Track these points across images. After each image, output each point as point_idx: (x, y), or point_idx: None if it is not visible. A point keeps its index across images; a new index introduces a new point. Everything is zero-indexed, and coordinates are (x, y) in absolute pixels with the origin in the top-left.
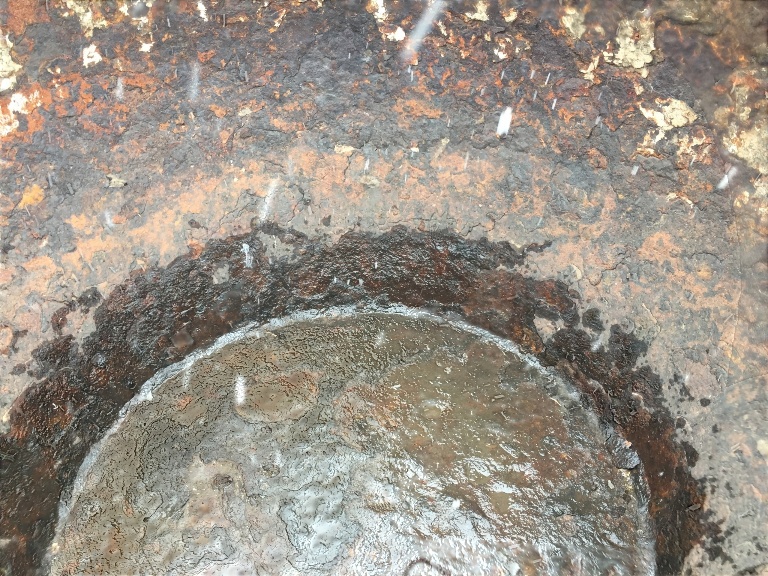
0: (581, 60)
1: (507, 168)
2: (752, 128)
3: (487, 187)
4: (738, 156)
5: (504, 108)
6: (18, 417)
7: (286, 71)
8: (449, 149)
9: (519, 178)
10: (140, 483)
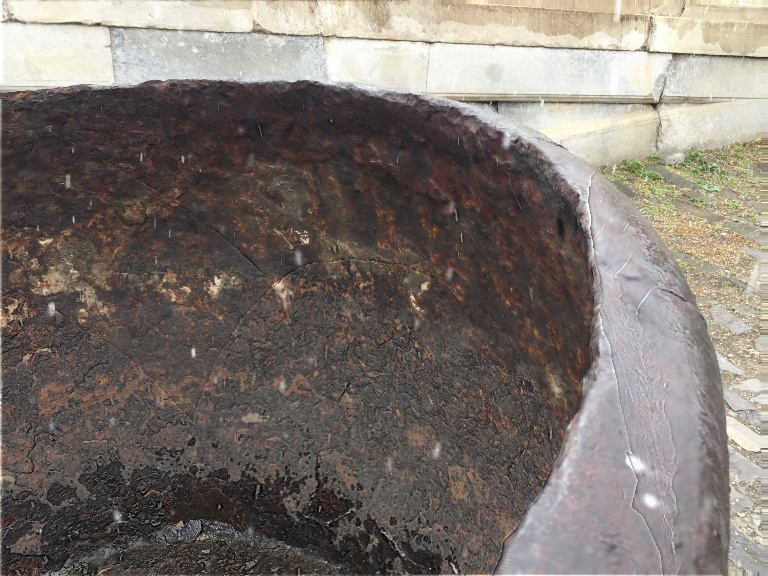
0: None
1: None
2: (48, 270)
3: None
4: (54, 293)
5: None
6: None
7: None
8: None
9: None
10: None
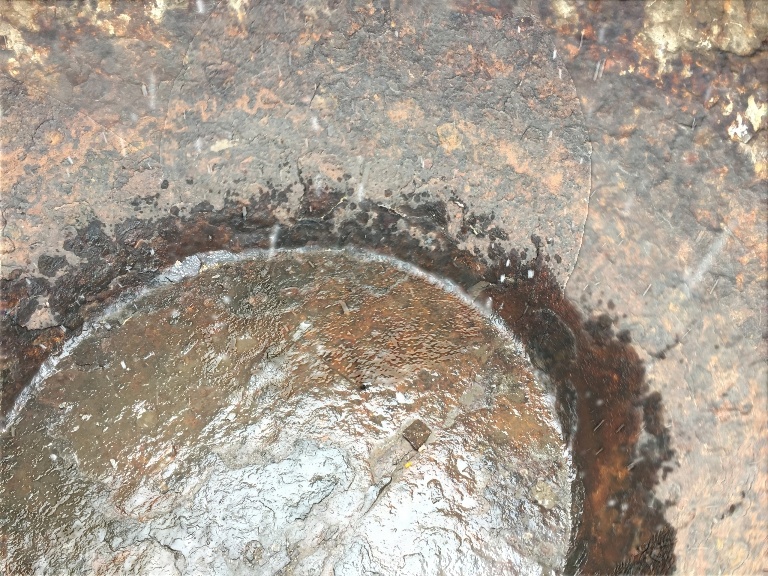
0: None
1: None
2: None
3: None
4: None
5: None
6: None
7: None
8: None
9: None
10: None
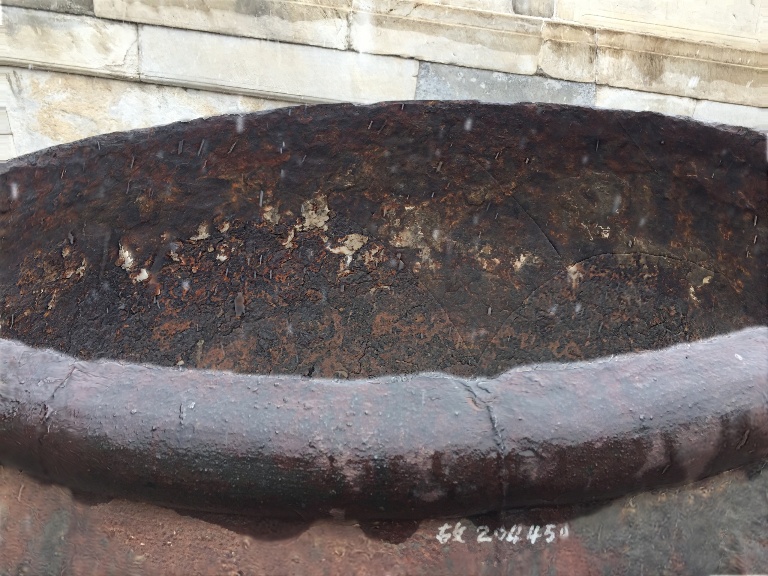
0: (281, 237)
1: (255, 336)
2: (404, 229)
3: (248, 359)
4: (403, 247)
5: (235, 295)
6: None
7: (61, 349)
8: (206, 348)
9: (268, 338)
10: None
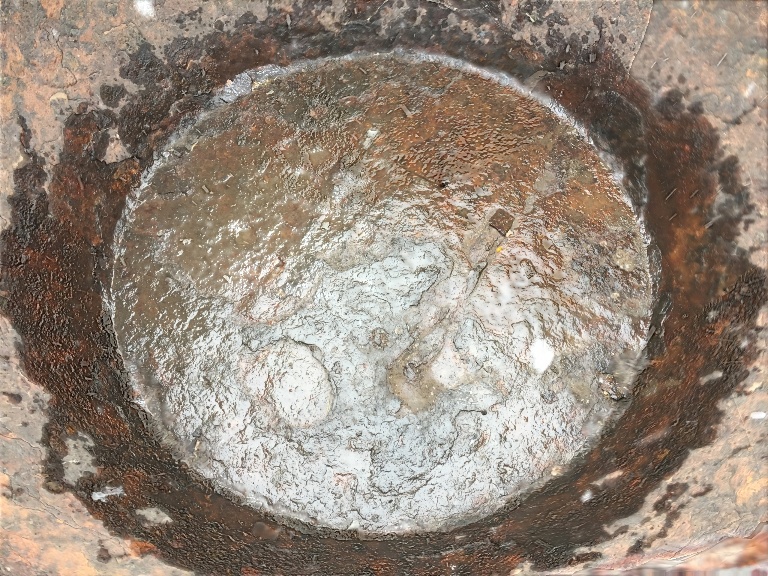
0: None
1: None
2: None
3: None
4: None
5: None
6: (501, 571)
7: None
8: None
9: None
10: (455, 448)
